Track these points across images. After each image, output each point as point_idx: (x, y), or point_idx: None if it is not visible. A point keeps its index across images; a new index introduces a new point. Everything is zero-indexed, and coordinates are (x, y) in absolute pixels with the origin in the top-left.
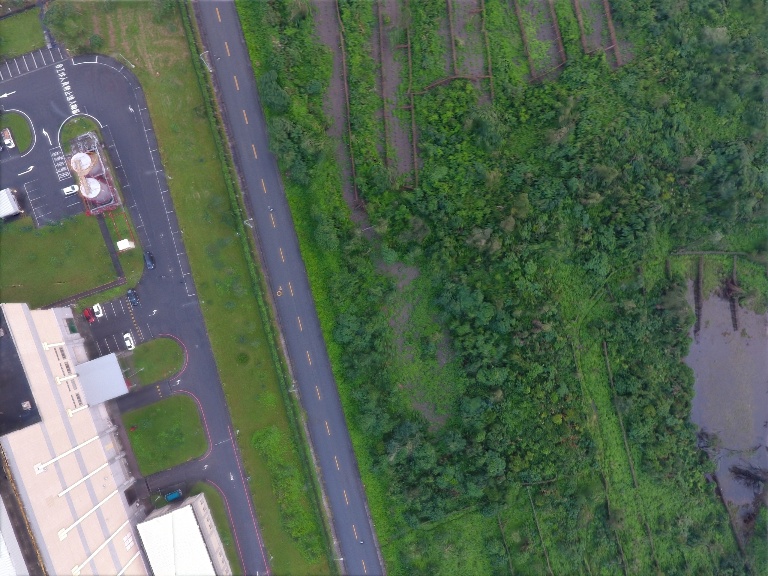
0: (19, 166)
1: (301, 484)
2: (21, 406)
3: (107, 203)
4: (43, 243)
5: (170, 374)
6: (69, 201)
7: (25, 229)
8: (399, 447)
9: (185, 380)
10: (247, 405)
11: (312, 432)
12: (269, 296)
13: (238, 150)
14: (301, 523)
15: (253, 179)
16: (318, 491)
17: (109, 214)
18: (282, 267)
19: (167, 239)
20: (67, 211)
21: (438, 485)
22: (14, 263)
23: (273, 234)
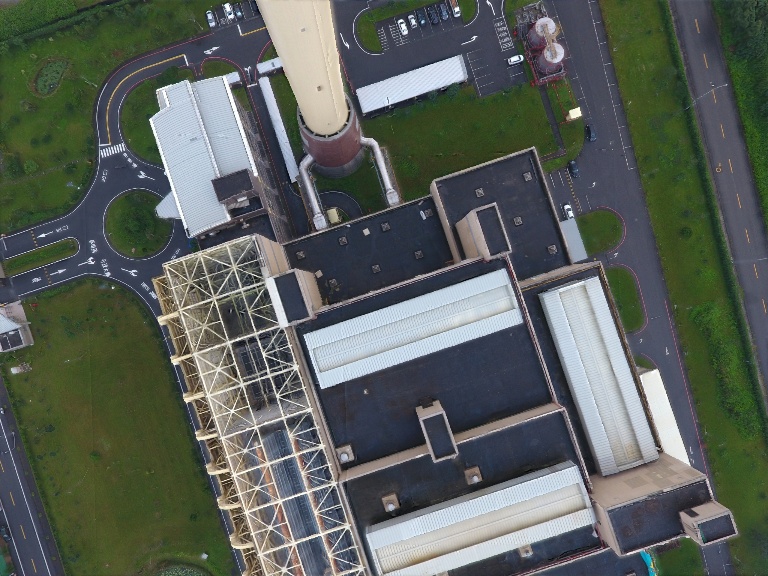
0: (462, 35)
1: (739, 361)
2: (547, 250)
3: (557, 72)
4: (485, 112)
5: (609, 246)
6: (511, 71)
7: (472, 97)
8: None
9: (623, 253)
10: (687, 280)
11: (748, 310)
12: (709, 172)
13: (680, 24)
14: (741, 399)
15: (695, 54)
16: (755, 369)
17: (552, 85)
18: (722, 143)
19: (608, 112)
20: (509, 81)
21: None
22: (456, 132)
23: (714, 110)
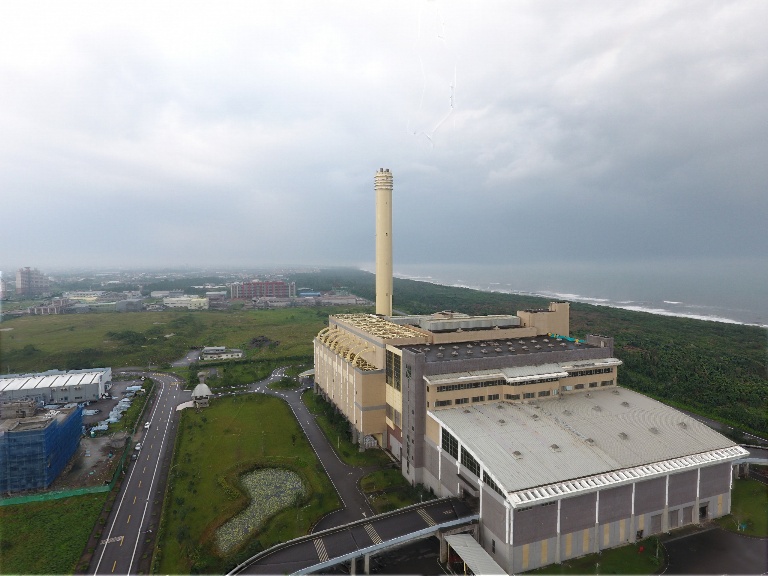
0: None
1: None
2: None
3: None
4: None
5: None
6: None
7: None
8: None
9: None
10: None
11: None
12: None
13: None
14: None
15: None
16: None
17: None
18: None
19: None
20: None
21: None
22: None
23: None
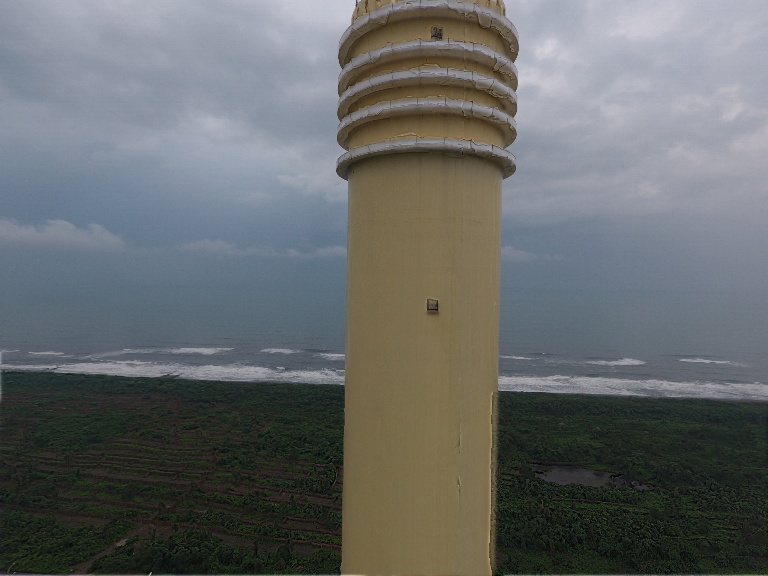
0: None
1: None
2: None
3: None
4: None
5: None
6: None
7: None
8: (648, 574)
9: None
10: None
11: None
12: None
13: None
14: None
15: None
16: None
17: None
18: None
19: None
20: None
21: (680, 574)
22: None
23: None
